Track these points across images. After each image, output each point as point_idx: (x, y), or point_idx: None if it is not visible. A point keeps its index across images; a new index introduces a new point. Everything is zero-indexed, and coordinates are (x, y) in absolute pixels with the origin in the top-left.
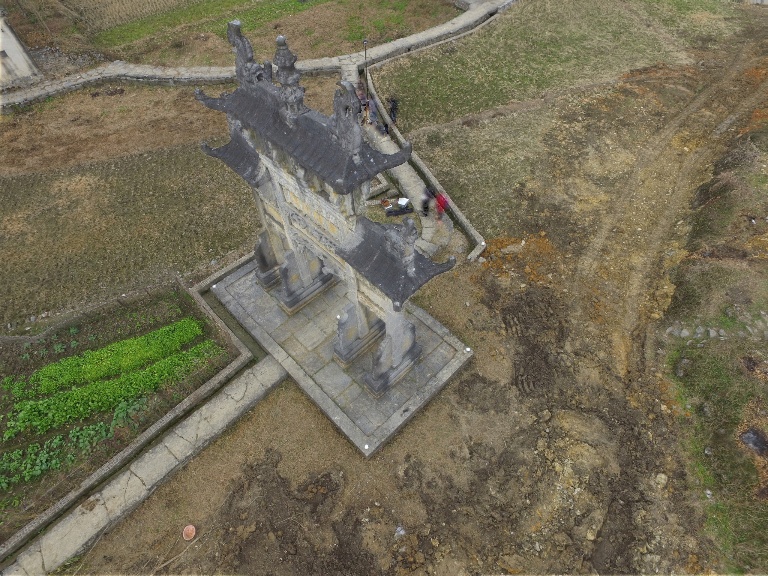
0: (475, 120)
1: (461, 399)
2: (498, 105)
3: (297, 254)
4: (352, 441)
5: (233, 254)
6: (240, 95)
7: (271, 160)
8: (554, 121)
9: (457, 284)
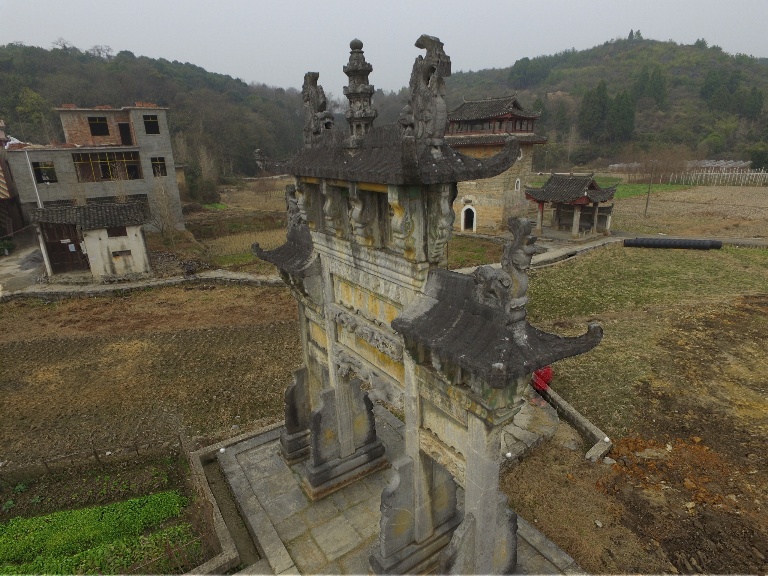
0: (568, 322)
1: None
2: (593, 313)
3: (339, 394)
4: None
5: (262, 420)
6: (303, 154)
7: (325, 234)
8: (667, 329)
9: (575, 491)
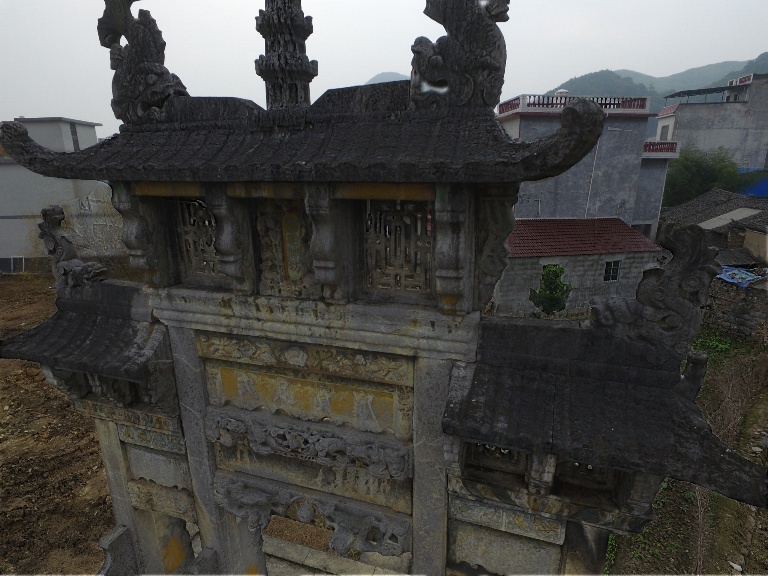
0: None
1: None
2: None
3: None
4: None
5: None
6: None
7: None
8: None
9: None
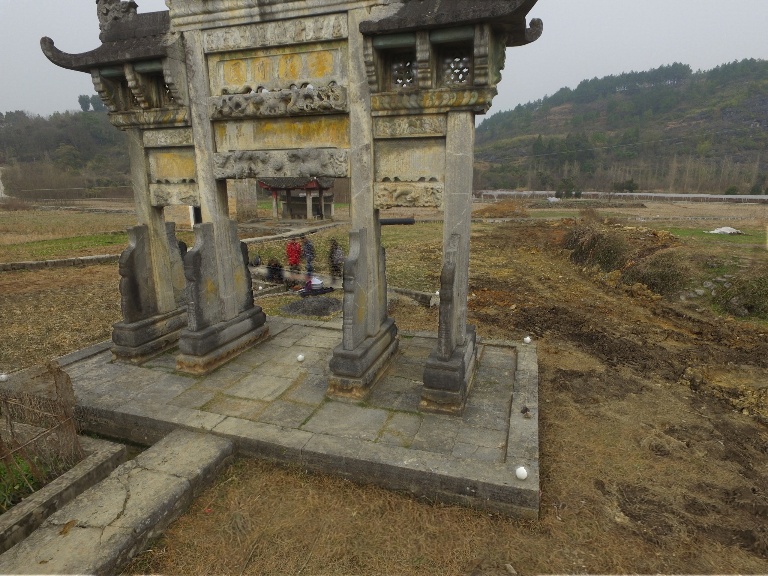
0: None
1: (575, 395)
2: None
3: (219, 229)
4: (477, 485)
5: None
6: None
7: None
8: None
9: None
